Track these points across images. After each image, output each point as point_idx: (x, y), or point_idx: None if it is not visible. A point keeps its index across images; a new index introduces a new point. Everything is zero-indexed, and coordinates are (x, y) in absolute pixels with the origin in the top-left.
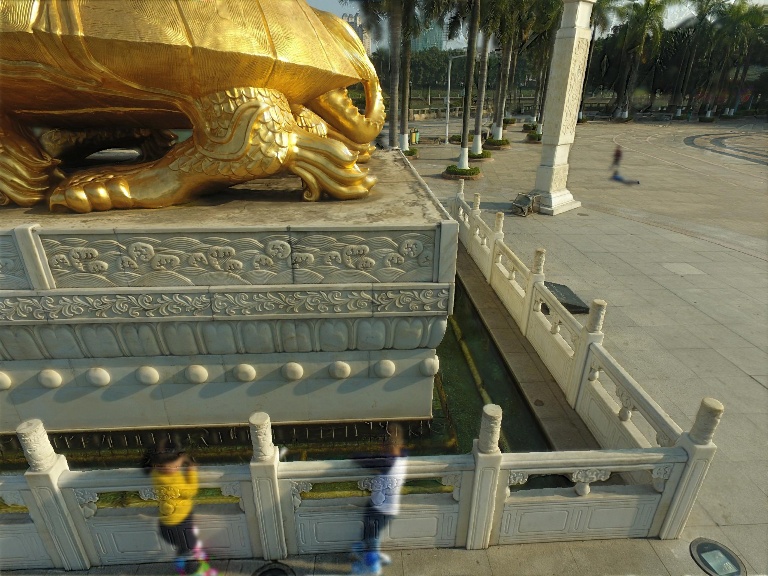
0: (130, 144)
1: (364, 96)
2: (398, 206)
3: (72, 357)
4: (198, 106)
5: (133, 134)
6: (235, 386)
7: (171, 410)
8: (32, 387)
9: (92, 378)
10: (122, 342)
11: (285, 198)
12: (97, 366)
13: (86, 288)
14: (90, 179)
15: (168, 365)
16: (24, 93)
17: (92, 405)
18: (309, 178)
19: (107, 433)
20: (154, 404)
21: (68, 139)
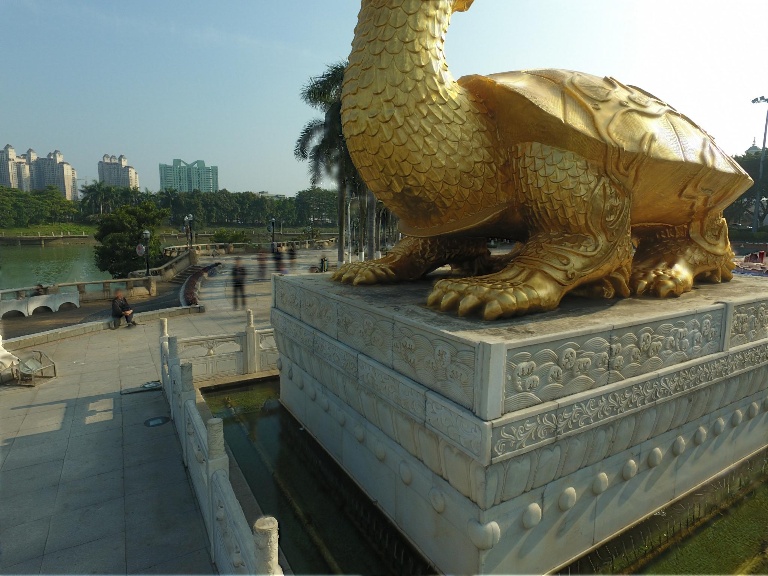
0: (469, 259)
1: (224, 231)
2: (765, 281)
3: (712, 411)
4: (707, 221)
5: (486, 250)
6: (762, 416)
7: (736, 448)
8: (689, 448)
9: (721, 427)
10: (739, 389)
11: (697, 283)
12: (719, 416)
13: (739, 346)
14: (662, 273)
15: (743, 406)
16: (651, 211)
17: (709, 456)
18: (720, 268)
19: (712, 482)
20: (731, 445)
21: (443, 255)
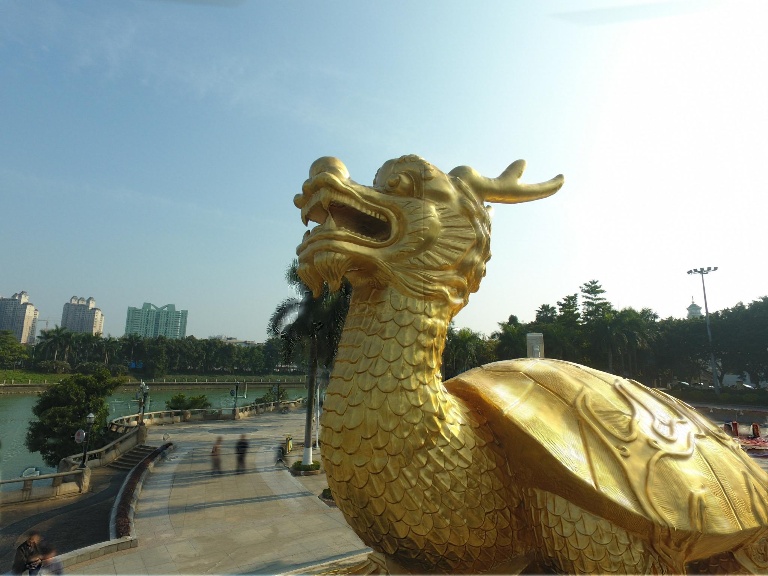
0: None
1: (182, 395)
2: None
3: None
4: None
5: None
6: None
7: None
8: None
9: None
10: None
11: None
12: None
13: None
14: None
15: None
16: None
17: None
18: None
19: None
20: None
21: None
